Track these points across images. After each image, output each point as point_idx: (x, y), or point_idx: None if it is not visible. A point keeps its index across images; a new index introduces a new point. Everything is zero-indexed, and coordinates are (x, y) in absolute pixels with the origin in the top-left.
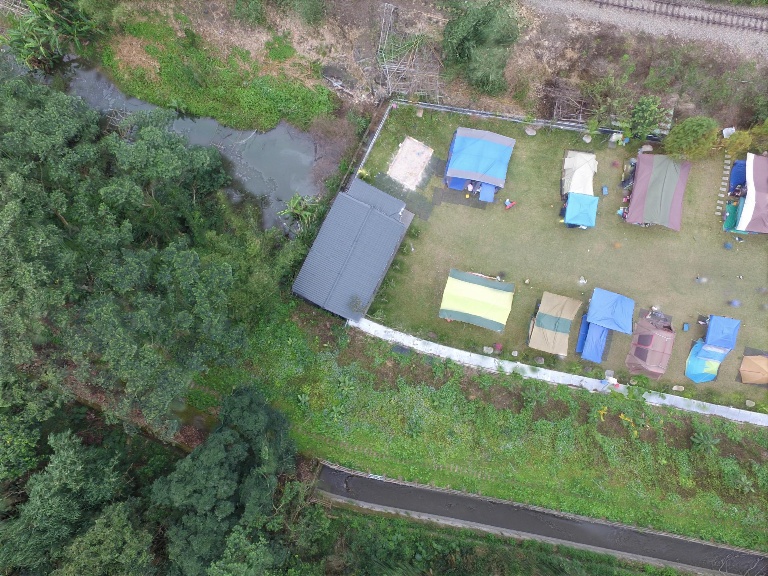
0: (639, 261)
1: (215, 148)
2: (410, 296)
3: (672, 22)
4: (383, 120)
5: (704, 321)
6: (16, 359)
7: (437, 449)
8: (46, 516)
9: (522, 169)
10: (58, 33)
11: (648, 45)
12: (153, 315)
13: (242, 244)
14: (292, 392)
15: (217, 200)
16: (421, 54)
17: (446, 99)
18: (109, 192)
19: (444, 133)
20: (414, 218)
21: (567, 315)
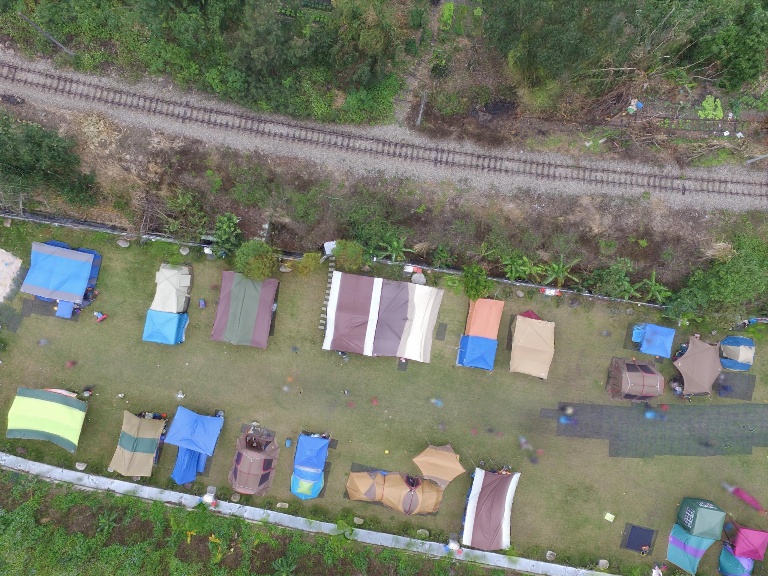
0: (240, 375)
1: None
2: None
3: (257, 138)
4: None
5: None
6: None
7: None
8: None
9: (117, 281)
10: None
11: (232, 161)
12: None
13: None
14: None
15: None
16: (1, 165)
17: (45, 207)
18: None
19: None
20: (1, 330)
21: (149, 434)
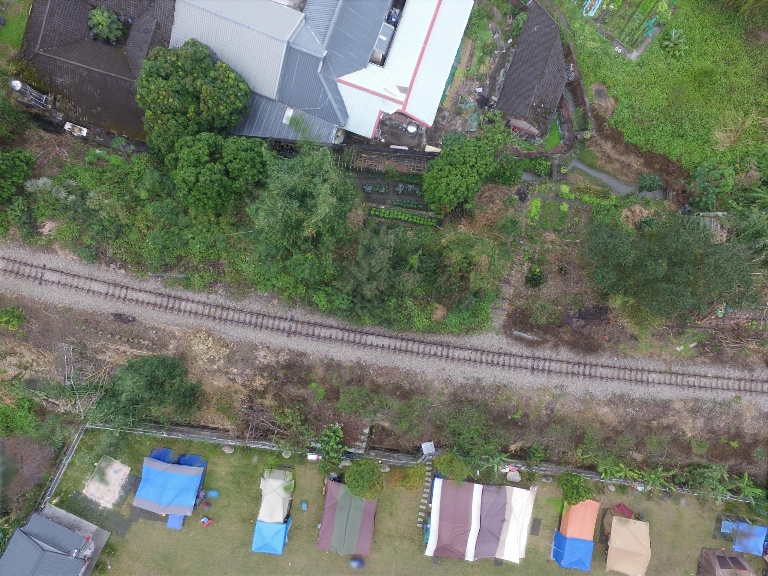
0: (341, 574)
1: None
2: None
3: (360, 350)
4: (78, 440)
5: None
6: None
7: None
8: None
9: (221, 484)
10: None
11: (336, 373)
12: None
13: None
14: None
15: None
16: None
17: (150, 410)
18: None
19: (142, 451)
20: (111, 536)
21: None
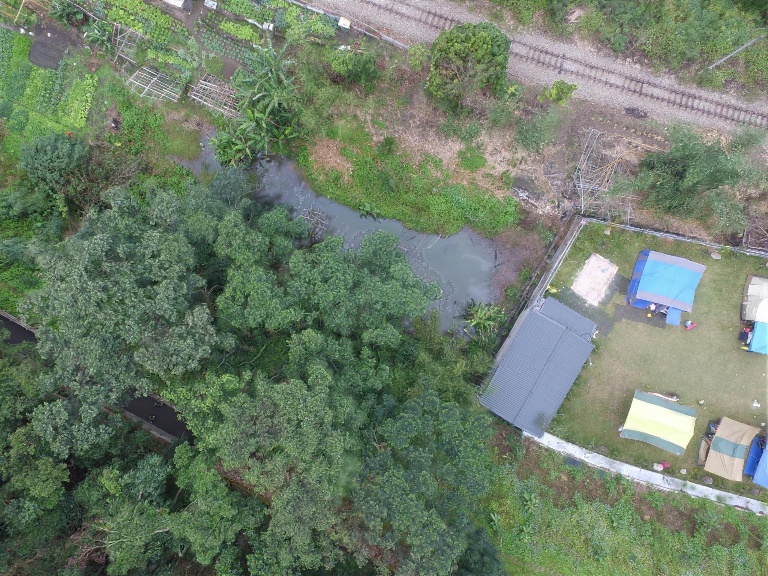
0: None
1: (402, 252)
2: (585, 409)
3: None
4: (572, 236)
5: None
6: (323, 526)
7: (622, 574)
8: None
9: (704, 291)
10: (267, 138)
11: None
12: None
13: (438, 357)
14: (483, 509)
15: None
16: (616, 175)
17: None
18: (372, 337)
19: (630, 252)
20: None
21: (744, 441)
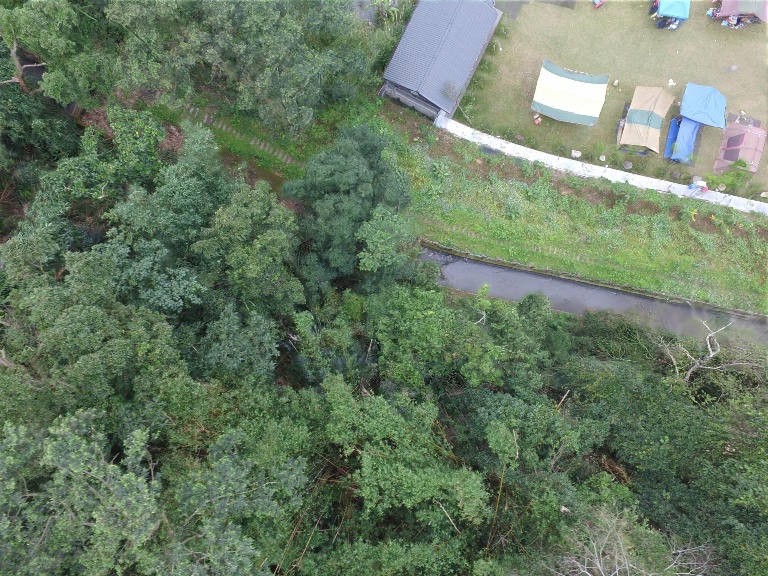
0: (728, 64)
1: None
2: (498, 98)
3: None
4: None
5: None
6: (162, 8)
7: (536, 230)
8: (183, 196)
9: None
10: None
11: None
12: None
13: None
14: None
15: None
16: None
17: None
18: None
19: None
20: (502, 17)
21: (659, 111)
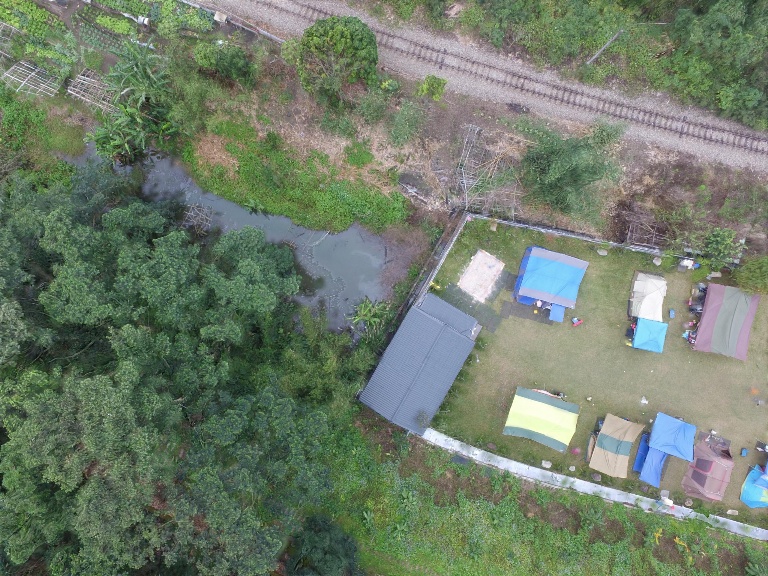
0: (701, 385)
1: (288, 248)
2: (472, 406)
3: (750, 155)
4: (457, 232)
5: (762, 448)
6: (126, 524)
7: (497, 572)
8: None
9: (591, 287)
10: (145, 133)
11: (725, 177)
12: (253, 470)
13: (315, 354)
14: (357, 507)
15: (286, 298)
16: (500, 171)
17: (519, 212)
18: (209, 333)
19: (516, 248)
20: (481, 330)
21: (629, 438)
